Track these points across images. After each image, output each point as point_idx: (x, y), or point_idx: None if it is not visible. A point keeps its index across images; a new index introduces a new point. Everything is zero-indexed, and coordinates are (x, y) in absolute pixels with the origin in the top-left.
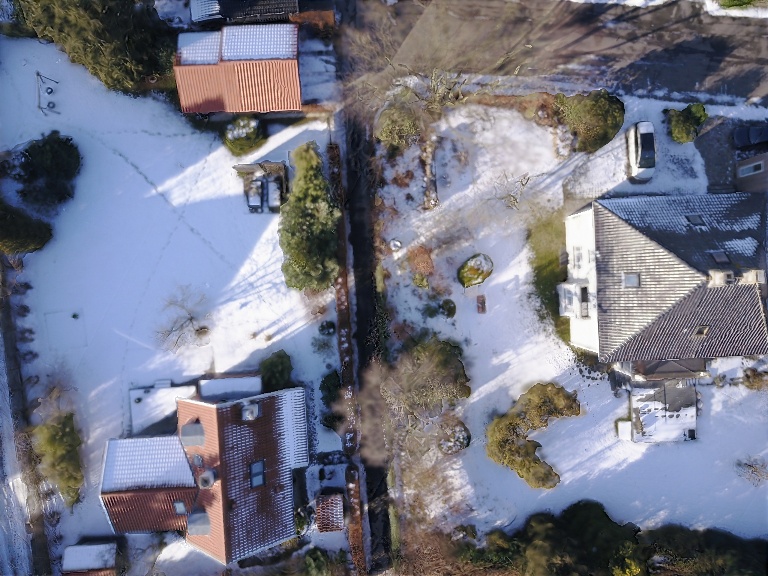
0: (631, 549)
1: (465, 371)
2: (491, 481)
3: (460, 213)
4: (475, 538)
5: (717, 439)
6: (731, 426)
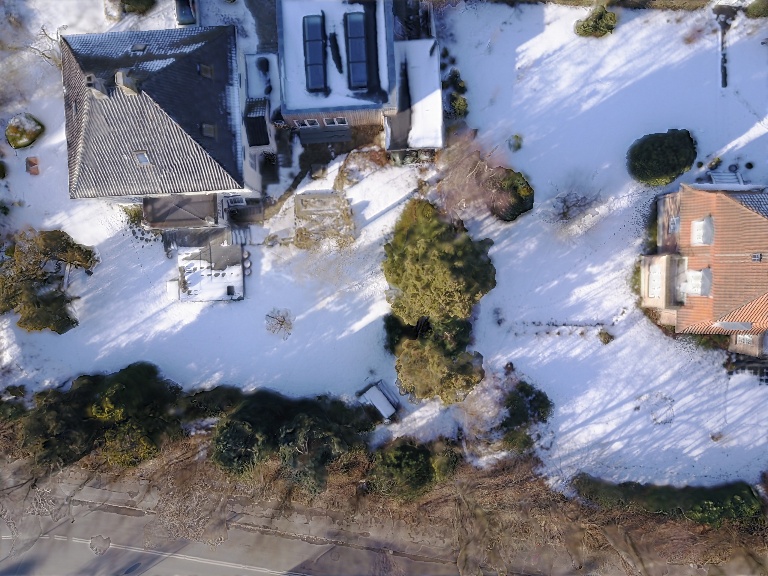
0: (116, 390)
1: (19, 233)
2: (45, 342)
3: (12, 75)
4: (25, 398)
5: (266, 299)
6: (280, 285)
